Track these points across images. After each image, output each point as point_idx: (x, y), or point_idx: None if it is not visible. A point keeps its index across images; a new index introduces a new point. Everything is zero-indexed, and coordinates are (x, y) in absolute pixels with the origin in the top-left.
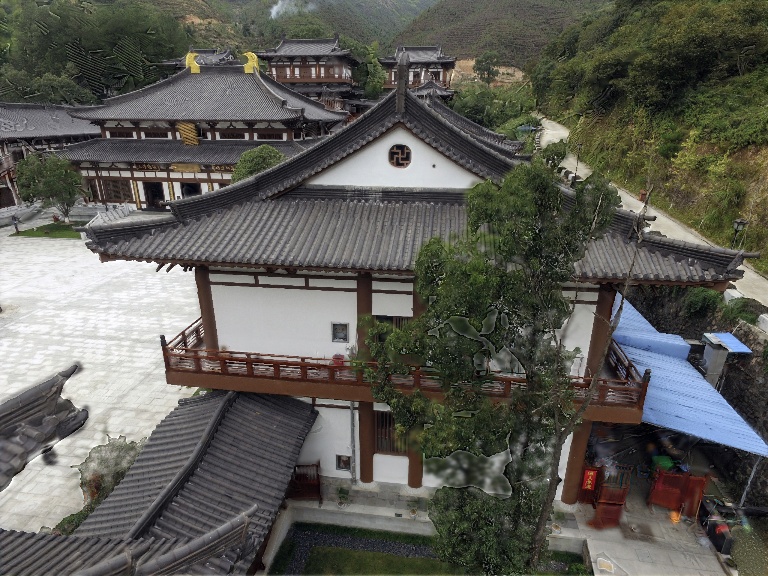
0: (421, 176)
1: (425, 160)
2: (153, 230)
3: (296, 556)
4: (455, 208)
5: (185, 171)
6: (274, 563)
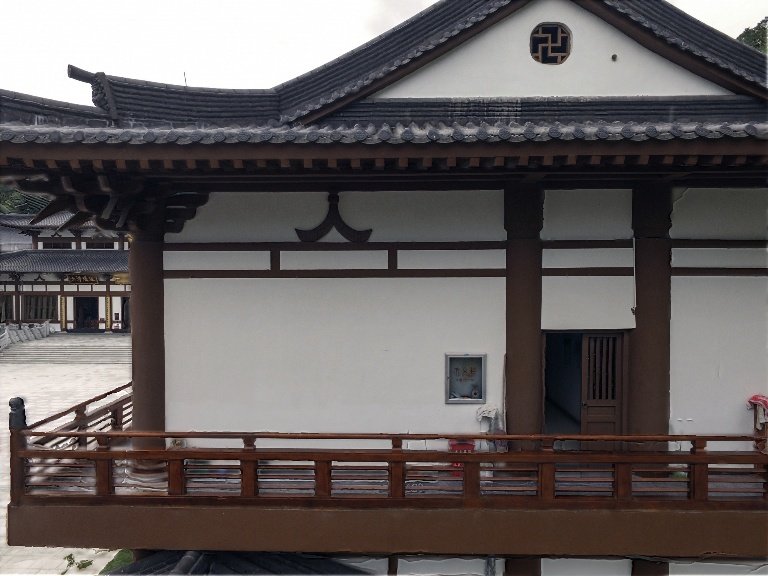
0: (591, 77)
1: (597, 48)
2: (38, 118)
3: None
4: (667, 123)
5: (129, 283)
6: None
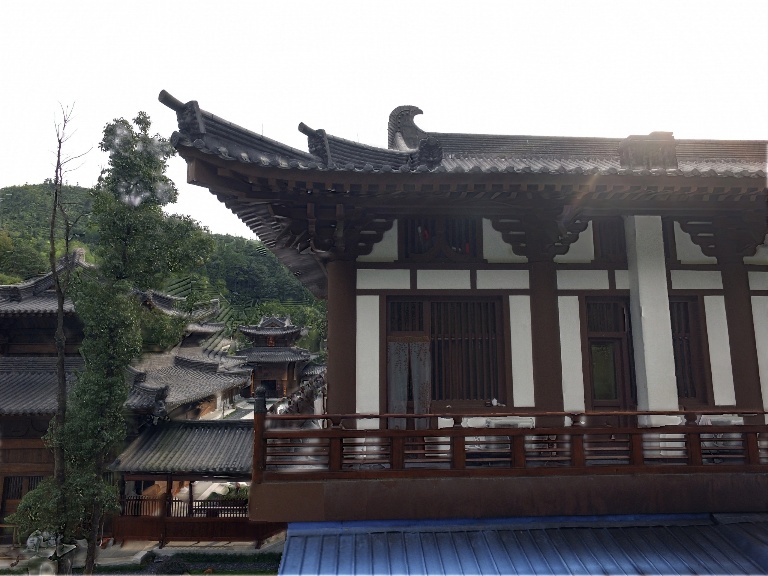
0: None
1: None
2: None
3: (273, 565)
4: None
5: None
6: (265, 554)
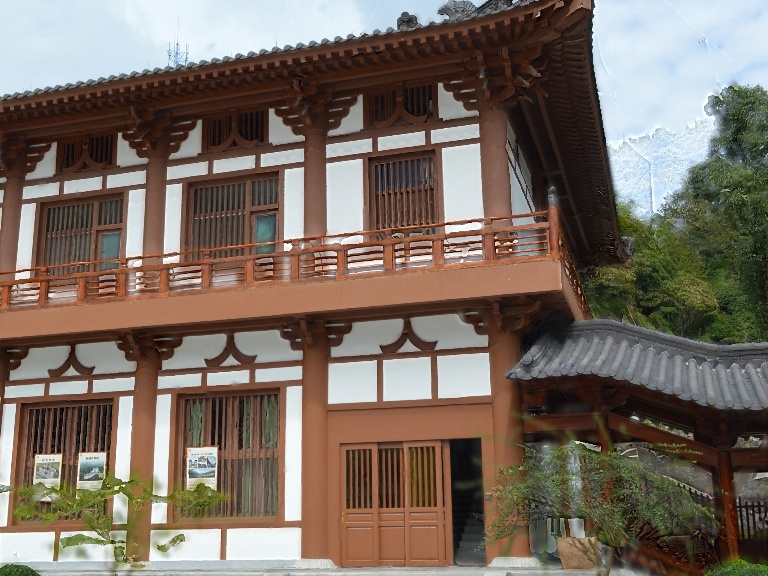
0: None
1: None
2: None
3: None
4: None
5: None
6: None
